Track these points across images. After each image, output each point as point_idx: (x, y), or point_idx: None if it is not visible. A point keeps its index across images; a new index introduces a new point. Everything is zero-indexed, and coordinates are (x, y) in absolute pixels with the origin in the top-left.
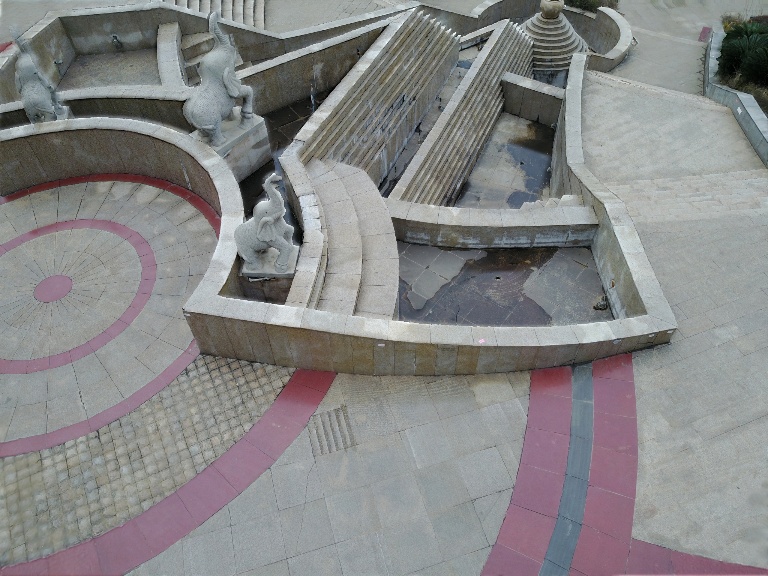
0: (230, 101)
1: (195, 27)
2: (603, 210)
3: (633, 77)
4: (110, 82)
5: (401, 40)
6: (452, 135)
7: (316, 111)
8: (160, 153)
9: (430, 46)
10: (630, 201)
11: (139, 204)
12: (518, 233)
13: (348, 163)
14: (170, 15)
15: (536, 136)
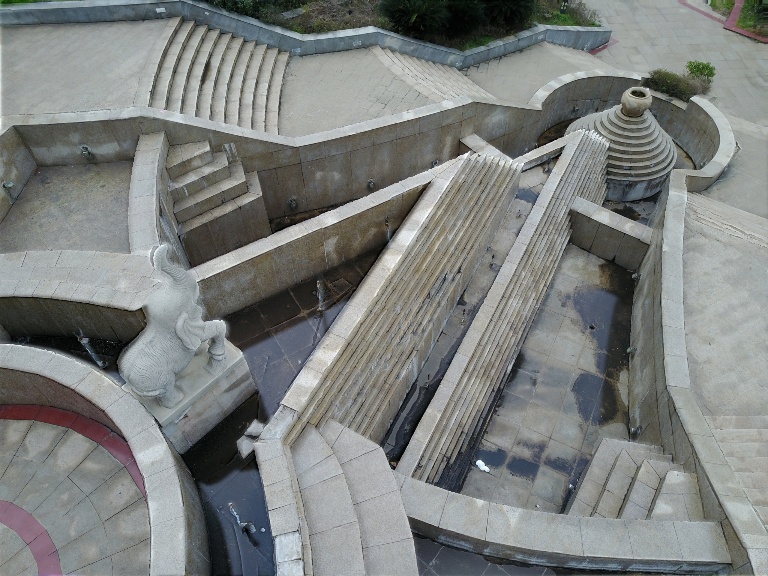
0: (188, 352)
1: (186, 136)
2: (744, 555)
3: (736, 201)
4: (72, 212)
5: (446, 204)
6: (506, 310)
7: (318, 346)
8: (90, 404)
9: (484, 194)
10: (765, 480)
11: (59, 470)
12: (606, 561)
13: (362, 401)
14: (154, 124)
15: (611, 284)
